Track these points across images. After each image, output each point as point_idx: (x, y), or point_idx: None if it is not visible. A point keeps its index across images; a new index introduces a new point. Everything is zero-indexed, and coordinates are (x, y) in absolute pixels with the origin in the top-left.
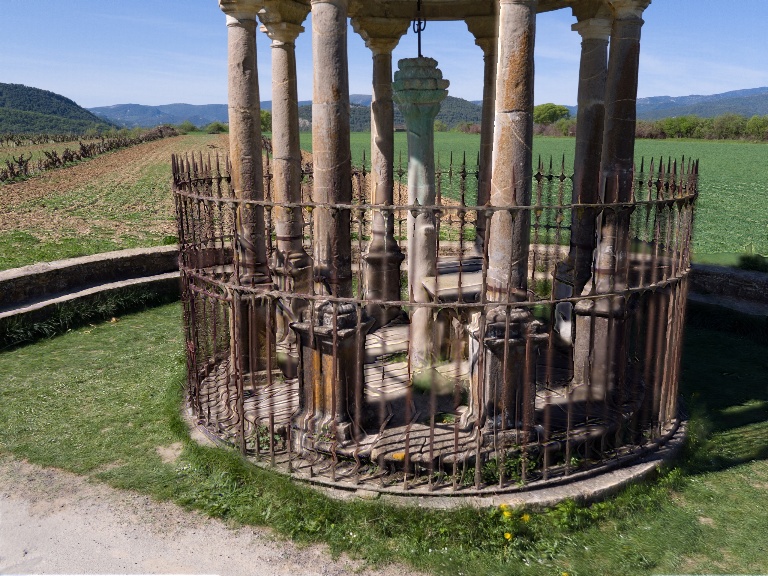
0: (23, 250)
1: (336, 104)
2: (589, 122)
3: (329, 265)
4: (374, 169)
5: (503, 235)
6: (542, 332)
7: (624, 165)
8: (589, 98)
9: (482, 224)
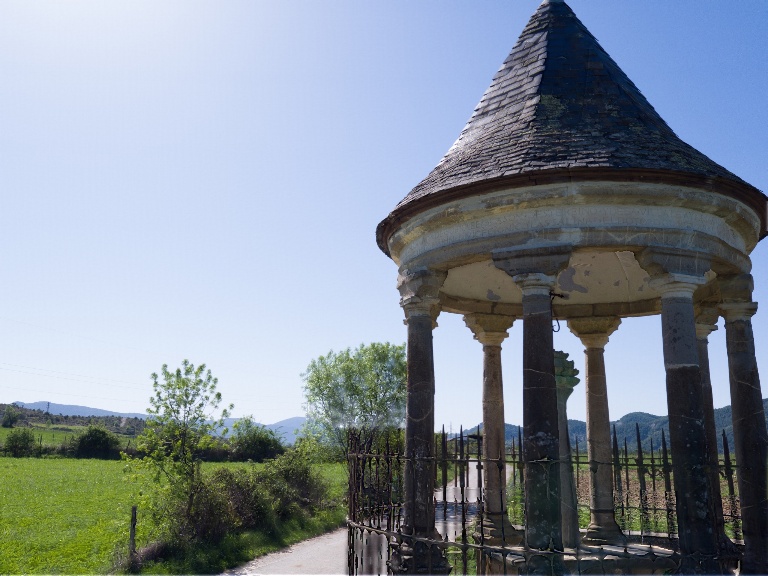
0: None
1: None
2: None
3: None
4: None
5: None
6: (407, 567)
7: None
8: None
9: None
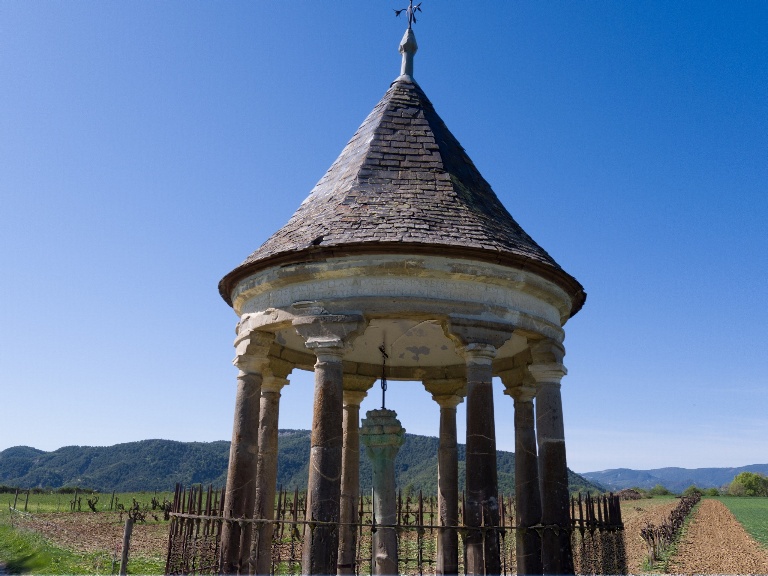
0: (284, 575)
1: (237, 446)
2: (542, 460)
3: (221, 569)
4: (438, 509)
5: (304, 551)
6: None
7: (475, 497)
8: (540, 437)
9: (518, 570)
